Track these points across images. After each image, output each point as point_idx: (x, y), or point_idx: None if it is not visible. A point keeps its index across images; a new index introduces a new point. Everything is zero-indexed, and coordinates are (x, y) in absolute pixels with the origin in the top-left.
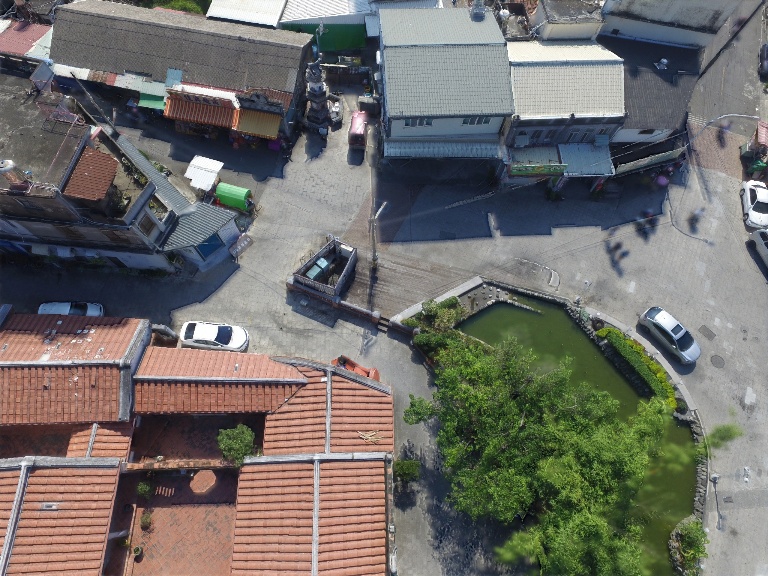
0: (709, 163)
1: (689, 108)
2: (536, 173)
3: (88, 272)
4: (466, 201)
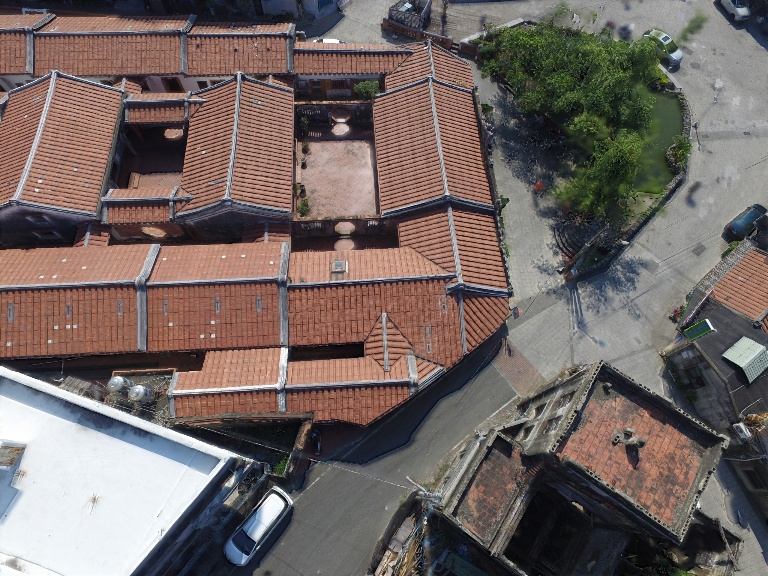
0: None
1: None
2: None
3: (234, 19)
4: None
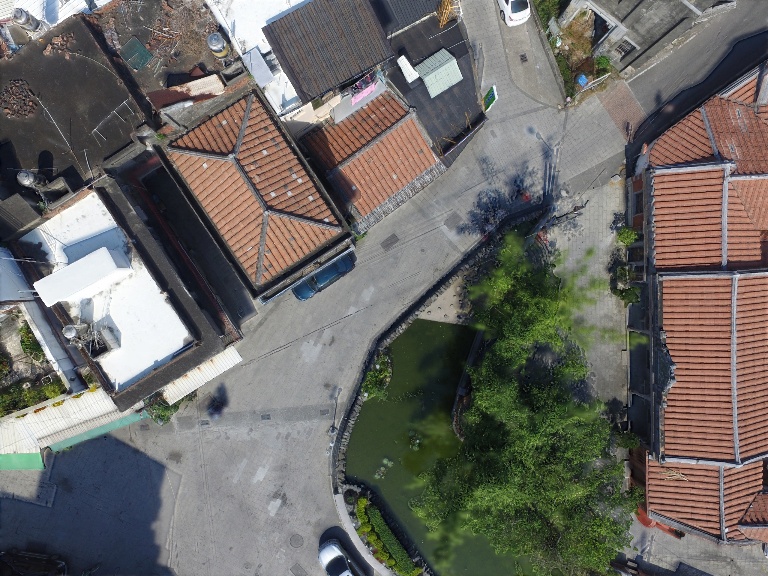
0: None
1: None
2: None
3: None
4: None
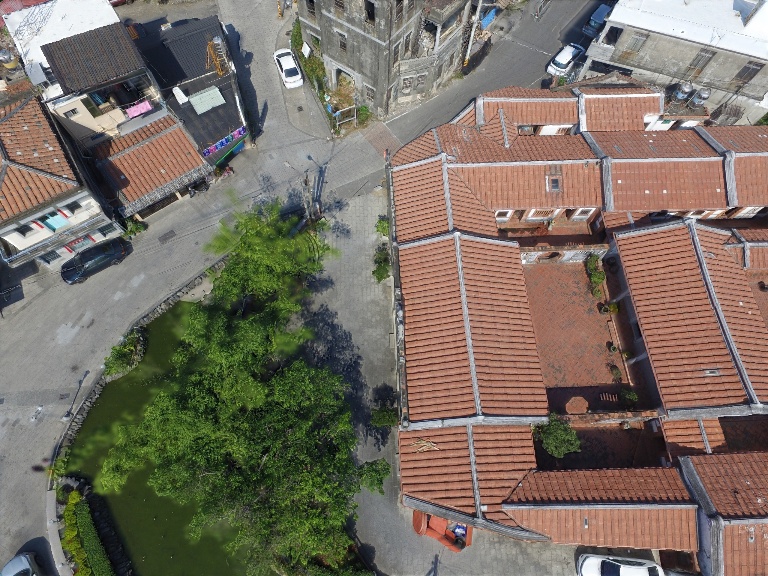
0: None
1: None
2: None
3: None
4: None
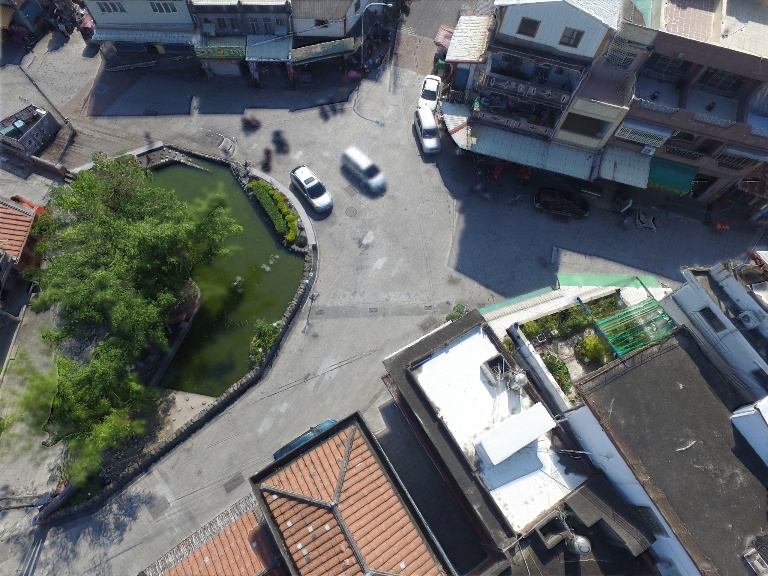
0: (404, 64)
1: (405, 21)
2: (221, 57)
3: None
4: (126, 65)
